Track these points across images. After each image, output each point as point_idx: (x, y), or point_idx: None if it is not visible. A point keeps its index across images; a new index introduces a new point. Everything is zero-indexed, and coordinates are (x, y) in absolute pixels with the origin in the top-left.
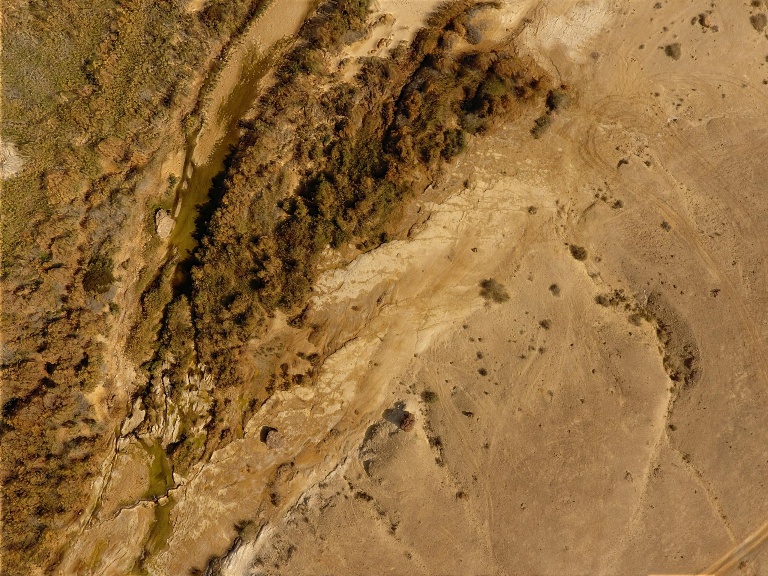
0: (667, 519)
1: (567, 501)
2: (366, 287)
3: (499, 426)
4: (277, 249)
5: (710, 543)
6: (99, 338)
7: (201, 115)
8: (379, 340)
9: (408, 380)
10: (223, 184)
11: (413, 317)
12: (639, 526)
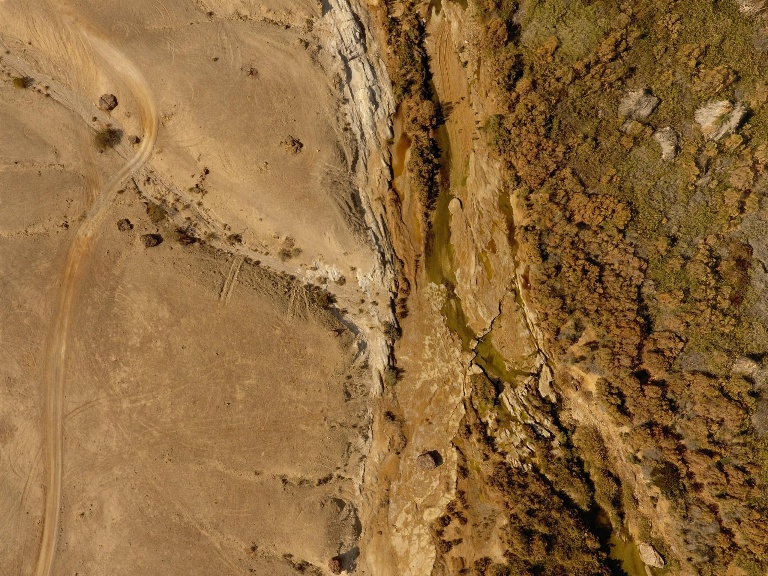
0: None
1: None
2: None
3: None
4: None
5: None
6: (626, 428)
7: None
8: None
9: None
10: None
11: None
12: None
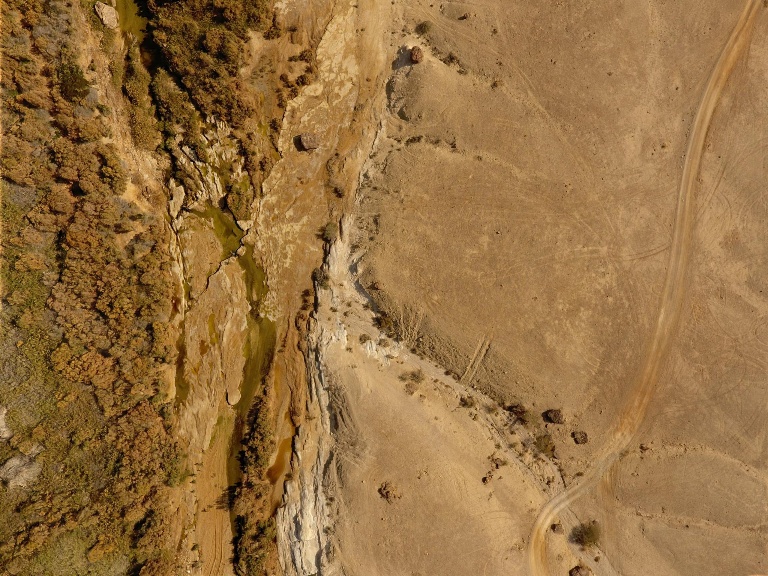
0: (681, 6)
1: (588, 36)
2: None
3: (496, 9)
4: None
5: (727, 5)
6: (104, 141)
7: None
8: (354, 8)
9: (398, 26)
10: None
11: None
12: (660, 25)
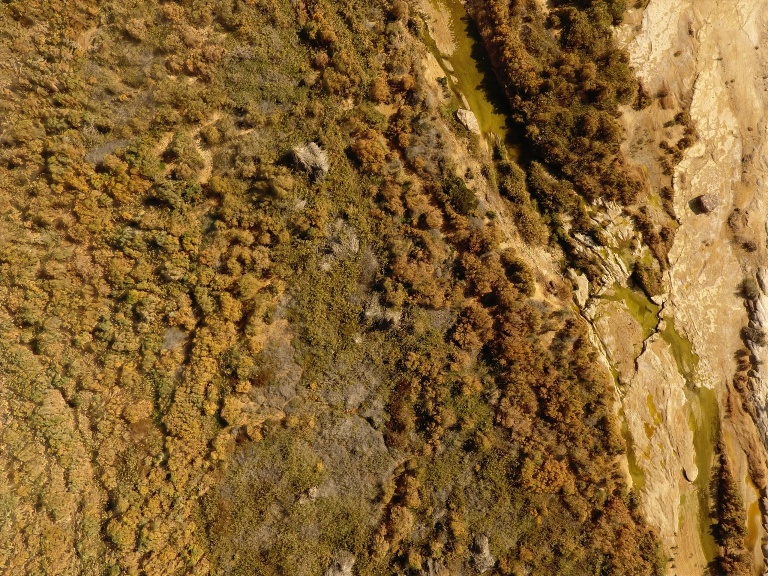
0: None
1: None
2: (672, 31)
3: None
4: (580, 59)
5: None
6: (502, 247)
7: (418, 15)
8: (718, 61)
9: None
10: (484, 53)
11: (728, 21)
12: None
